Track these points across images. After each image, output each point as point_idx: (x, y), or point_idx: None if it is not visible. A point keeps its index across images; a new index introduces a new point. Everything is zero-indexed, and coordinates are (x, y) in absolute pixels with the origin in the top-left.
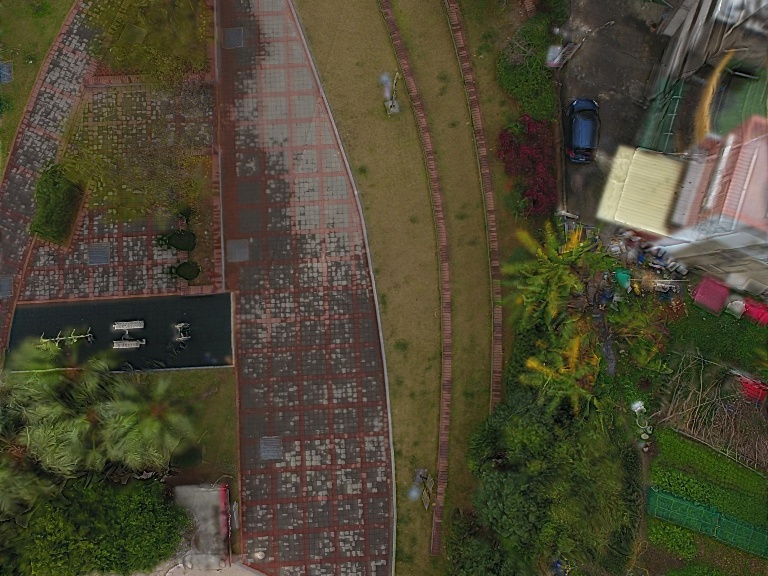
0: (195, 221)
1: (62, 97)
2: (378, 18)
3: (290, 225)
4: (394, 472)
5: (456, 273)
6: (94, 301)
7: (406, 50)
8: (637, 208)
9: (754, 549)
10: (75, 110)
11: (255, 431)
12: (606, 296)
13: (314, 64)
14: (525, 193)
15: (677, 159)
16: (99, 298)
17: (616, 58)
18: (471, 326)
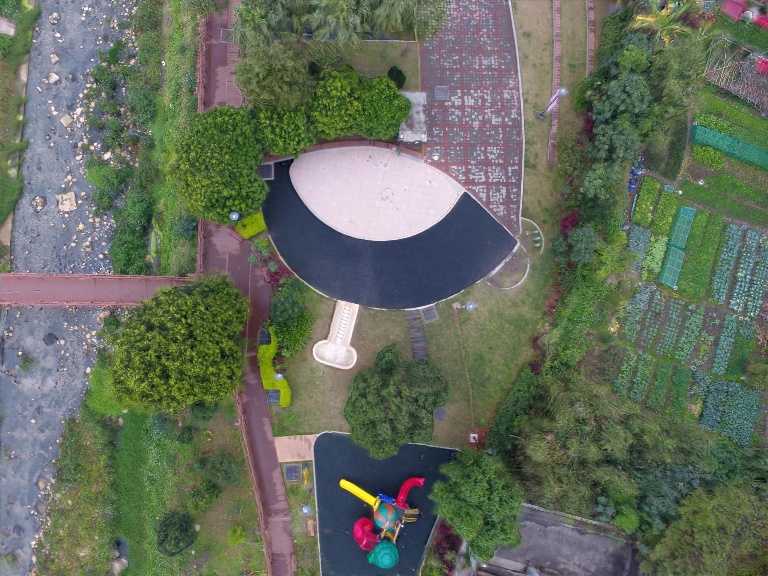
0: None
1: None
2: None
3: None
4: (523, 112)
5: None
6: None
7: None
8: None
9: (760, 162)
10: None
11: (431, 81)
12: (662, 5)
13: None
14: None
15: None
16: None
17: None
18: (573, 23)
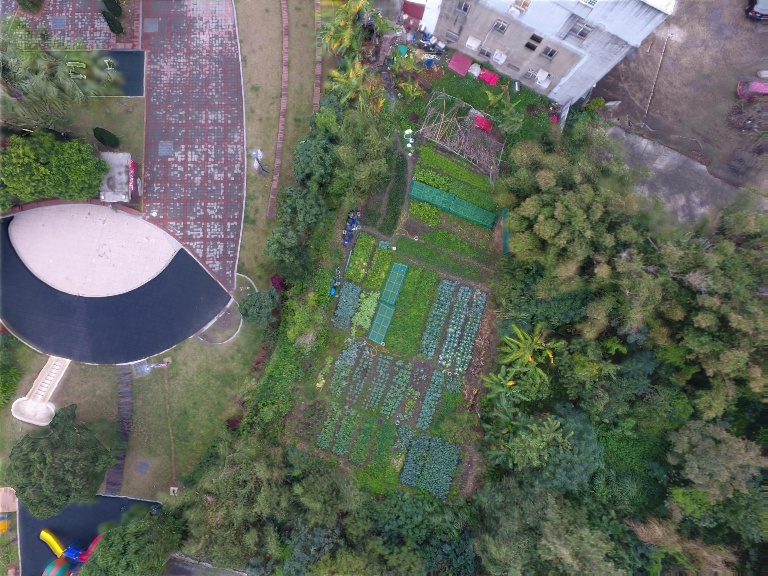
0: (123, 4)
1: None
2: None
3: (186, 10)
4: (246, 167)
5: (294, 43)
6: (54, 51)
7: None
8: None
9: (476, 217)
10: None
11: (155, 137)
12: (390, 58)
13: None
14: None
15: None
16: (57, 50)
17: None
18: (302, 77)
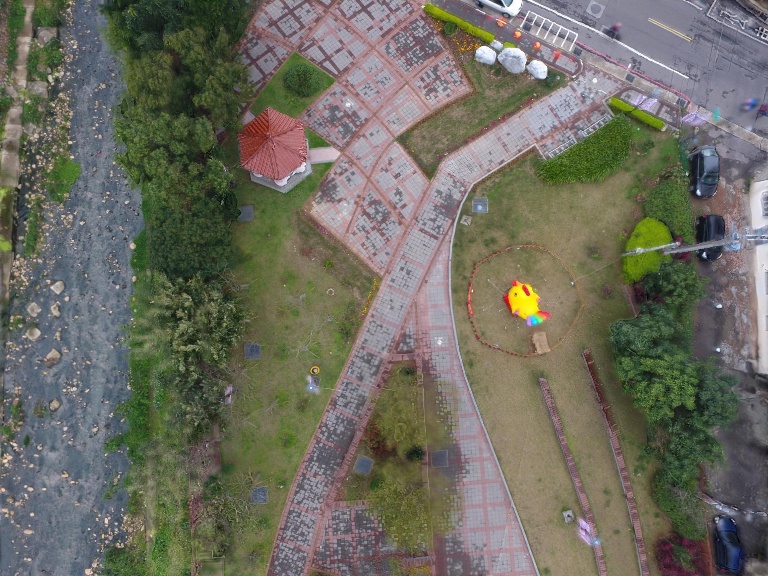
0: None
1: (307, 515)
2: (555, 439)
3: None
4: None
5: None
6: None
7: (579, 469)
8: None
9: None
10: (318, 526)
11: None
12: None
13: (506, 481)
14: None
15: None
16: None
17: (745, 474)
18: None
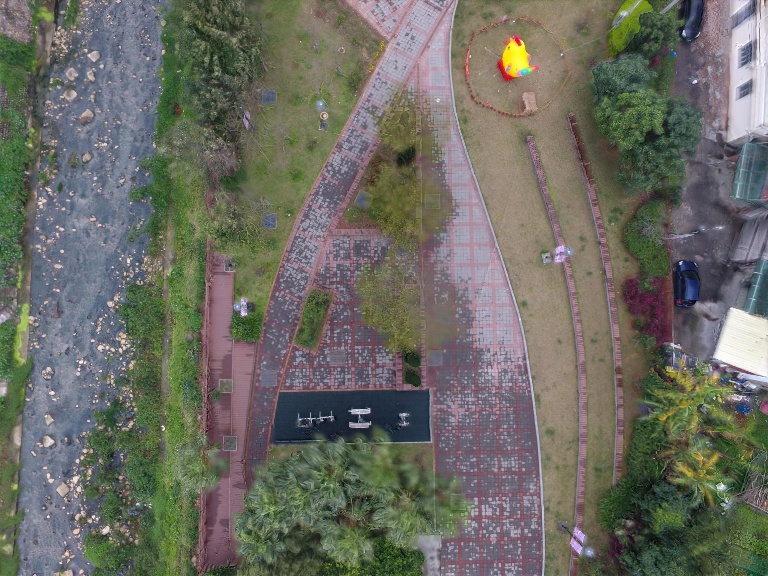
0: None
1: (311, 241)
2: (538, 191)
3: (472, 341)
4: (544, 522)
5: (591, 381)
6: (334, 392)
7: (558, 216)
8: (729, 350)
9: None
10: (320, 251)
11: (447, 489)
12: None
13: (492, 224)
14: (644, 327)
15: (758, 318)
16: (338, 390)
17: None
18: (601, 419)
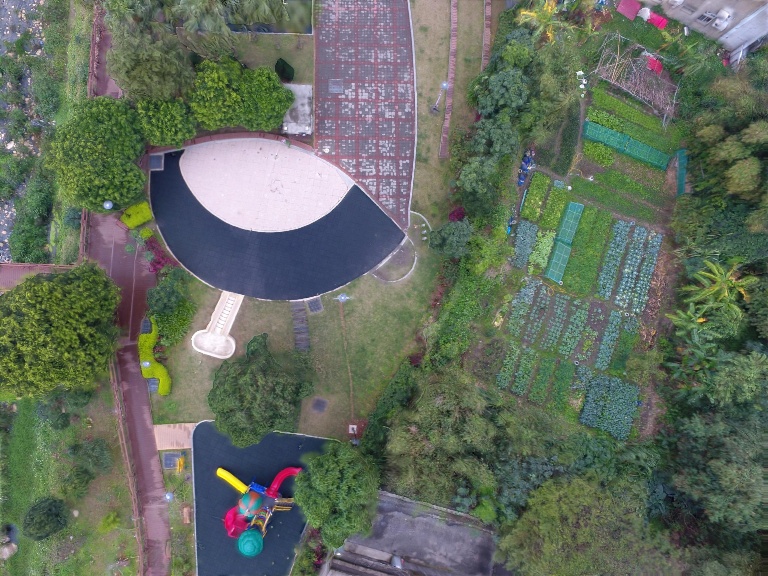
0: None
1: None
2: None
3: None
4: (416, 106)
5: None
6: None
7: None
8: None
9: (651, 158)
10: None
11: (325, 74)
12: (559, 1)
13: None
14: None
15: None
16: None
17: None
18: (470, 18)
